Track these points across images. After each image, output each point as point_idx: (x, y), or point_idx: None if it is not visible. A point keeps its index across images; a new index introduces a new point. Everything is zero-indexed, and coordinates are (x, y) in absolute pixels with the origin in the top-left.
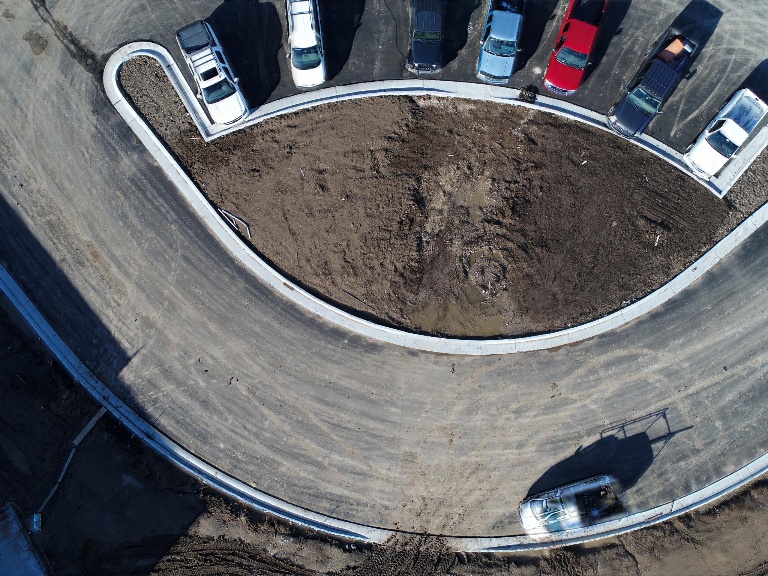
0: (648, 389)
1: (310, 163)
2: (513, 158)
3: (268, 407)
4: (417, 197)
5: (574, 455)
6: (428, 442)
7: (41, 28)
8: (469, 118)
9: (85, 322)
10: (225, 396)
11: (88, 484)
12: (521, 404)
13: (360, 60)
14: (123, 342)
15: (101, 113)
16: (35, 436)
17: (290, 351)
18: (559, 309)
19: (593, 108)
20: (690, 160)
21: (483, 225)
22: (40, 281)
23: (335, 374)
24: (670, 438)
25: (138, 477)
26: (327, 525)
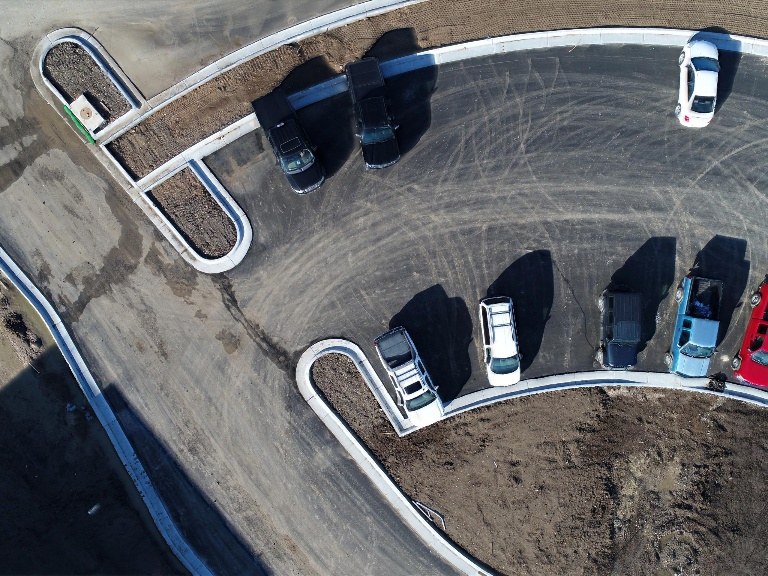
0: None
1: (503, 456)
2: (702, 443)
3: None
4: (609, 485)
5: None
6: None
7: (233, 327)
8: (658, 406)
9: None
10: None
11: None
12: None
13: (550, 353)
14: None
15: (294, 409)
16: None
17: None
18: None
19: None
20: None
21: (674, 509)
22: (239, 575)
23: None
24: None
25: None
26: None
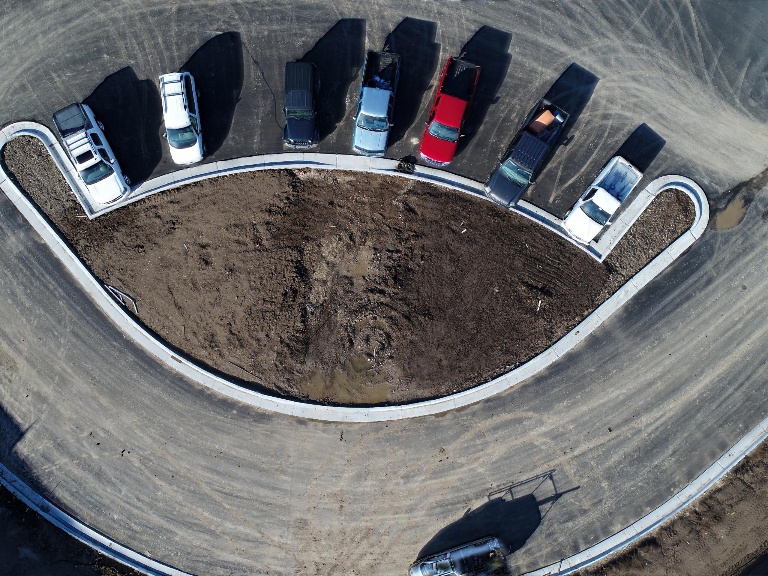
0: (534, 451)
1: (193, 238)
2: (395, 227)
3: (160, 478)
4: (300, 269)
5: (462, 518)
6: (318, 508)
7: None
8: (350, 189)
9: None
10: (117, 468)
11: None
12: (409, 469)
13: (240, 135)
14: (15, 418)
15: None
16: None
17: (180, 423)
18: (444, 375)
19: (472, 177)
20: (567, 227)
21: (367, 294)
22: None
23: (225, 444)
24: (557, 499)
25: (33, 550)
26: None
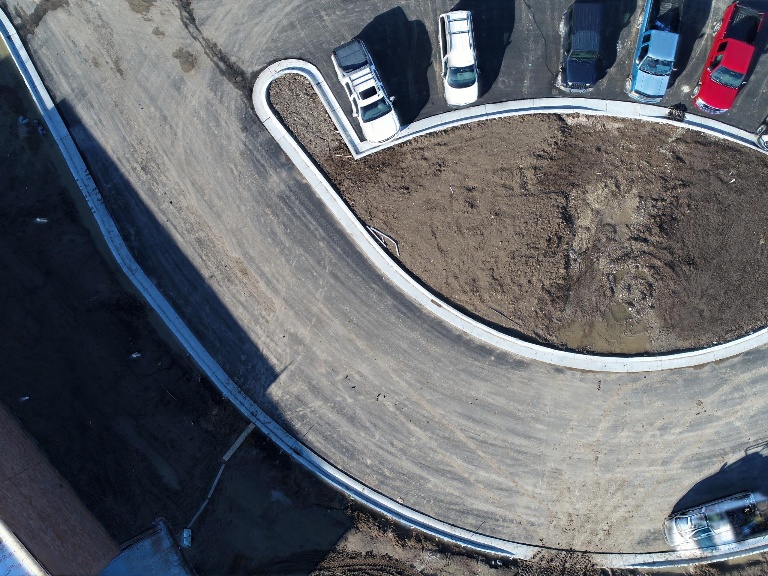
0: None
1: (459, 181)
2: (660, 176)
3: (415, 423)
4: (565, 215)
5: (719, 472)
6: (574, 459)
7: (191, 45)
8: (617, 136)
9: (233, 338)
10: (372, 412)
11: (237, 500)
12: (666, 421)
13: (509, 78)
14: (271, 358)
15: (250, 130)
16: (185, 452)
17: (437, 368)
18: (705, 327)
19: (741, 126)
20: None
21: (630, 243)
22: (189, 297)
23: (481, 391)
24: None
25: (287, 493)
26: (473, 541)
